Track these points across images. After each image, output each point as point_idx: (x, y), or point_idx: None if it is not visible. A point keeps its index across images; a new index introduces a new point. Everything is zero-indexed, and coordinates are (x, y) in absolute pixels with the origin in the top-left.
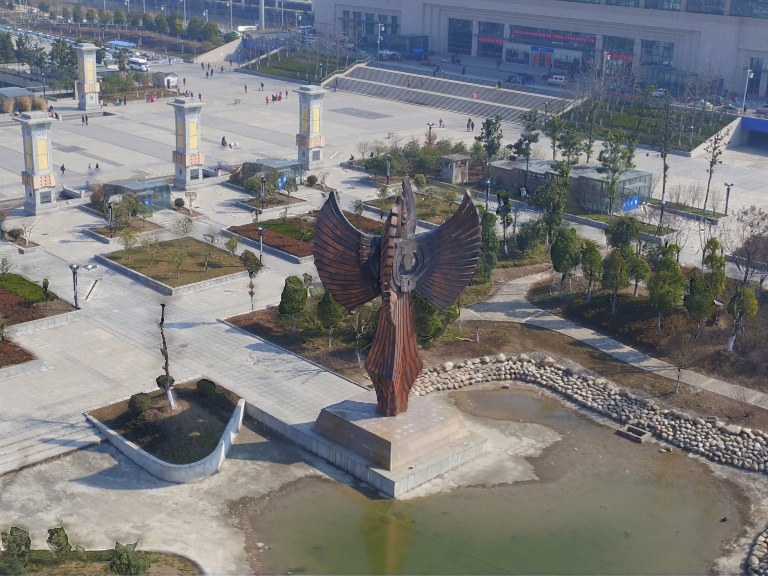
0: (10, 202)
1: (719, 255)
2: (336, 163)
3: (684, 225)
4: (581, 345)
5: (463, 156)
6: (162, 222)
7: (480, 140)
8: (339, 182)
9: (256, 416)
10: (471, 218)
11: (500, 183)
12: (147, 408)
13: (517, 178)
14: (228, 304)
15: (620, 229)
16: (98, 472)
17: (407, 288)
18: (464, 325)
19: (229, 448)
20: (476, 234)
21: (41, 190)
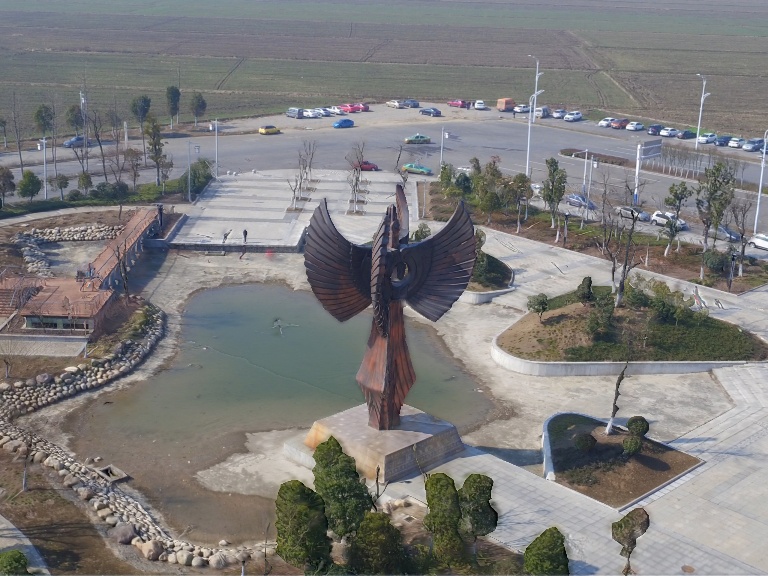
0: None
1: None
2: None
3: None
4: None
5: None
6: None
7: None
8: None
9: None
10: None
11: None
12: None
13: None
14: None
15: None
16: None
17: None
18: None
19: None
20: None
21: None
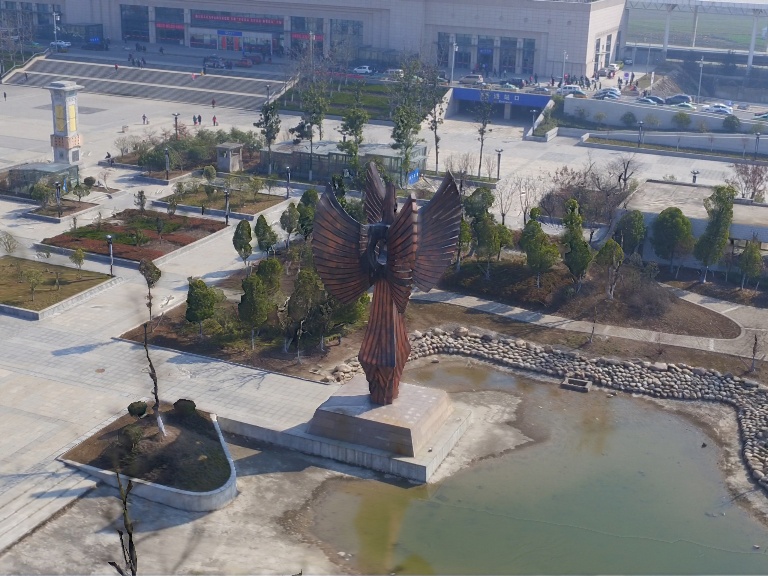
0: None
1: (577, 213)
2: (93, 162)
3: (471, 192)
4: (476, 312)
5: (235, 144)
6: None
7: (259, 126)
8: (113, 182)
9: (232, 429)
10: (452, 198)
11: (281, 168)
12: (139, 440)
13: (299, 161)
14: (109, 321)
15: (476, 199)
16: (118, 517)
17: None
18: None
19: None
20: (456, 213)
21: None
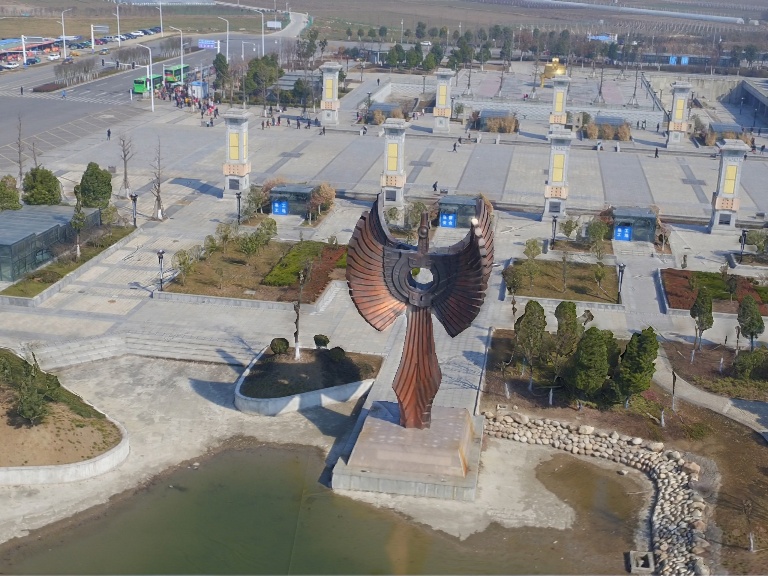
0: None
1: None
2: None
3: None
4: None
5: None
6: (622, 250)
7: None
8: None
9: None
10: (477, 248)
11: None
12: (281, 352)
13: None
14: None
15: None
16: (213, 381)
17: (419, 303)
18: (690, 409)
19: (313, 407)
20: None
21: (551, 199)
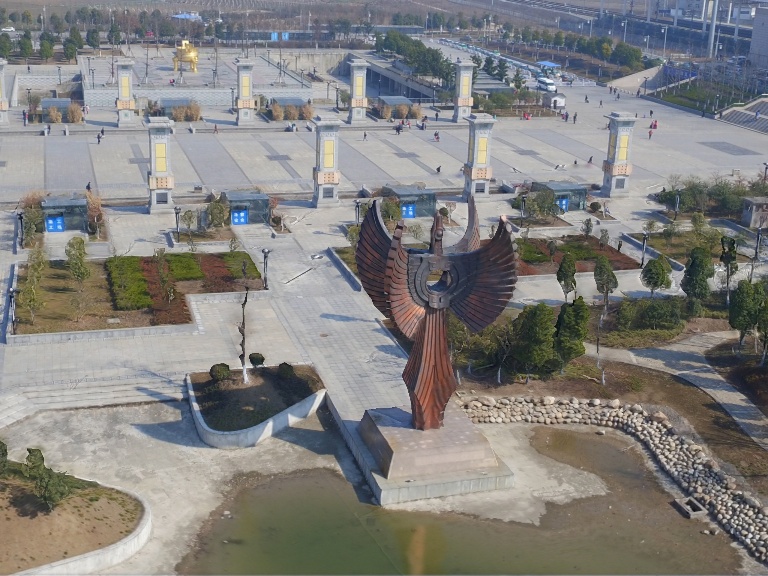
0: (311, 194)
1: None
2: (645, 194)
3: None
4: (716, 408)
5: None
6: None
7: None
8: (629, 212)
9: (330, 407)
10: (506, 243)
11: None
12: (224, 378)
13: None
14: None
15: None
16: (159, 423)
17: (438, 305)
18: (608, 365)
19: (282, 429)
20: (511, 261)
21: (324, 186)
